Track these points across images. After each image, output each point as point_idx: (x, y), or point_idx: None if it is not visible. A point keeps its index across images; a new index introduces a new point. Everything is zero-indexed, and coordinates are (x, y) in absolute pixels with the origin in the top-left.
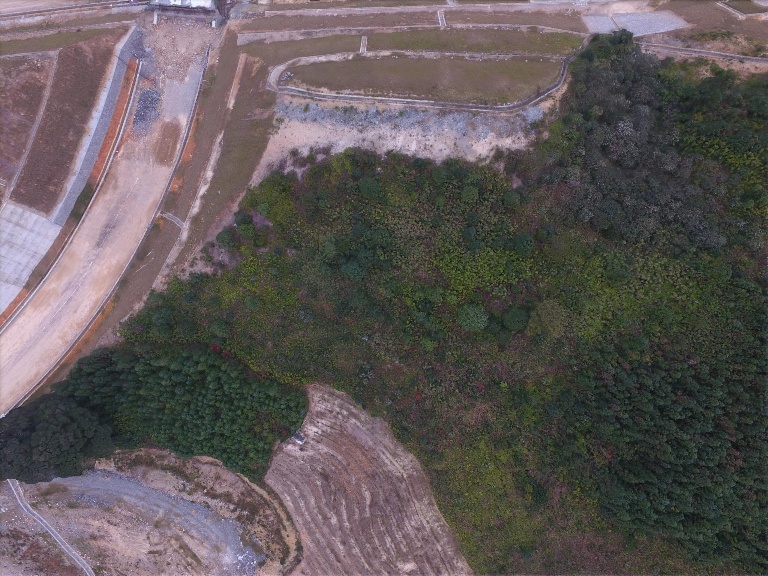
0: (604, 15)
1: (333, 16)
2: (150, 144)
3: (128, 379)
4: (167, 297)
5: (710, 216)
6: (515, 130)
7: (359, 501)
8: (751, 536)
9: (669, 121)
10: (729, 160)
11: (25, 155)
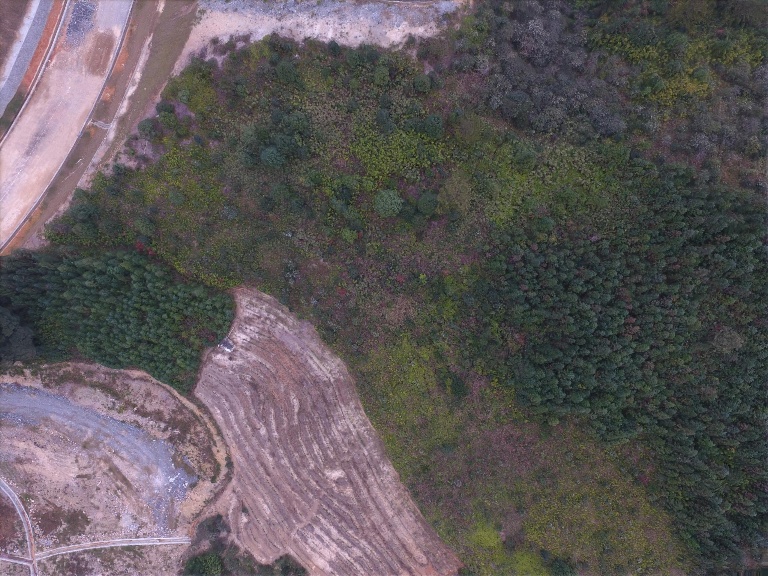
0: None
1: None
2: (83, 54)
3: (51, 280)
4: (91, 194)
5: (612, 104)
6: (427, 20)
7: (287, 408)
8: (652, 408)
9: (579, 26)
10: (630, 55)
11: None
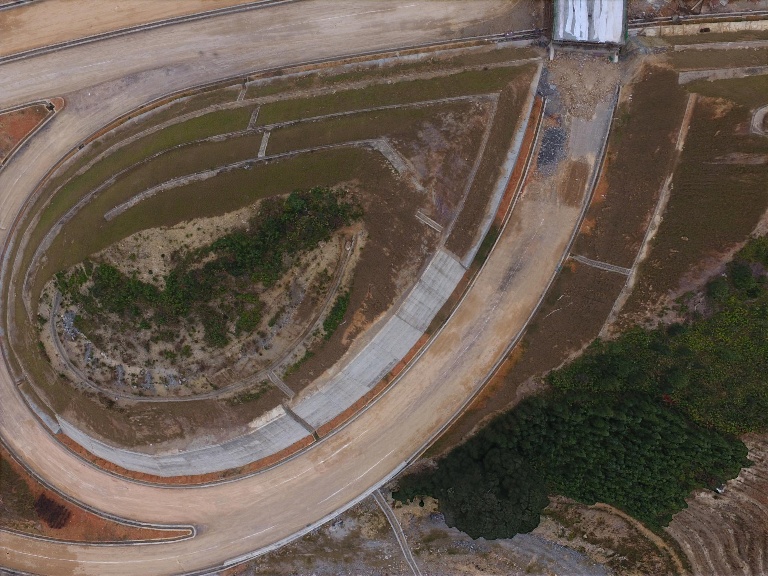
0: None
1: (747, 49)
2: (557, 184)
3: (563, 429)
4: (621, 346)
5: None
6: None
7: None
8: None
9: None
10: None
11: (463, 201)
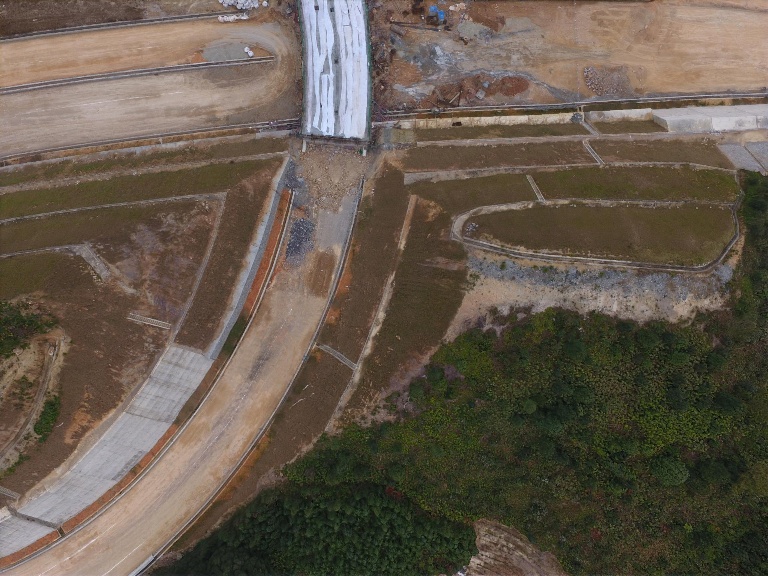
0: (737, 144)
1: (484, 147)
2: (304, 275)
3: (296, 523)
4: (343, 442)
5: None
6: (712, 291)
7: None
8: None
9: None
10: None
11: (191, 298)
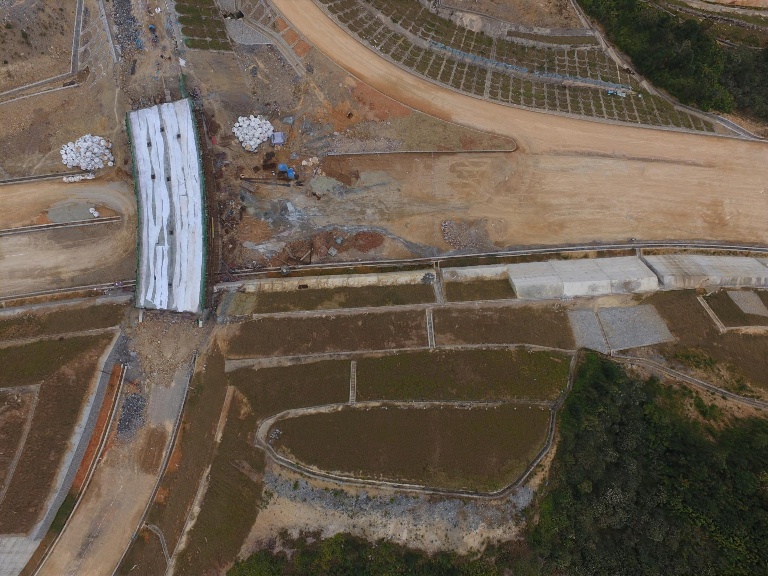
0: (589, 310)
1: (322, 319)
2: (135, 451)
3: None
4: None
5: None
6: (506, 519)
7: None
8: None
9: (656, 474)
10: (716, 538)
11: (4, 491)
